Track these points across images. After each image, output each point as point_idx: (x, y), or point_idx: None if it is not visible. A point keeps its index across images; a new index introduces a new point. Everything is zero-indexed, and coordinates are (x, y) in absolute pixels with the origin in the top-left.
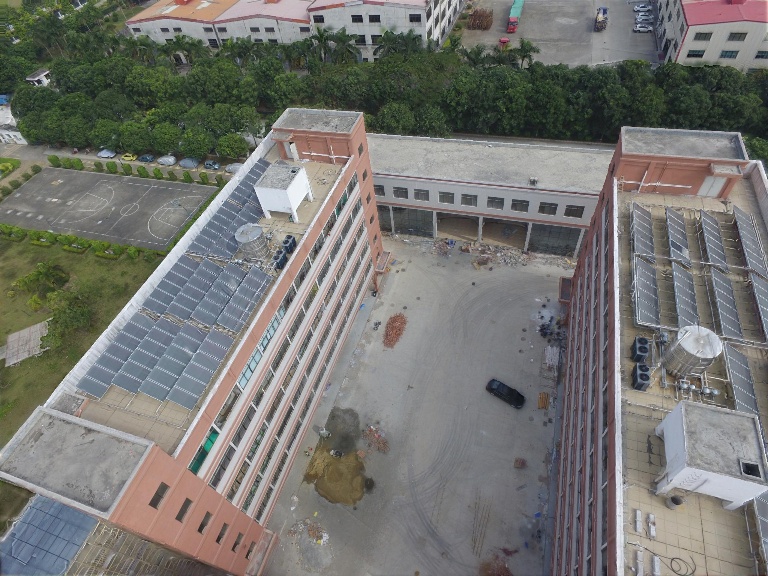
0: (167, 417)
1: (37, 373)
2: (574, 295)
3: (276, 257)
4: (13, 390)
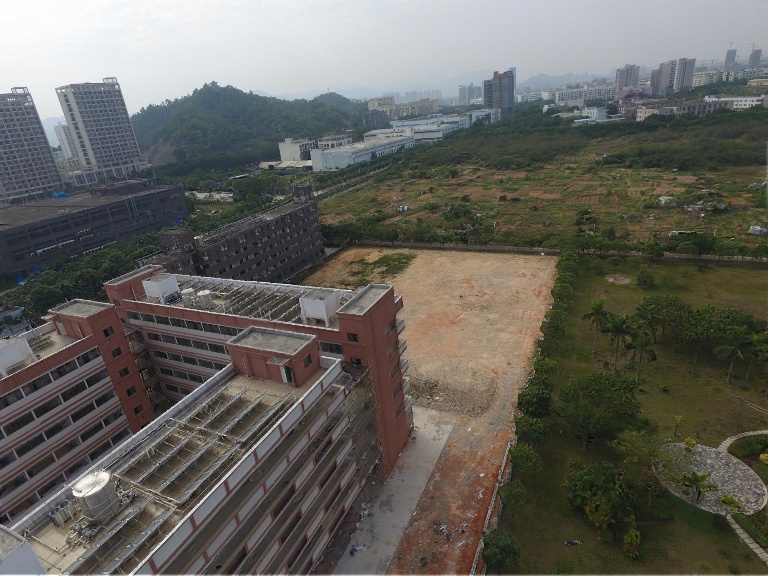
0: (239, 390)
1: None
2: None
3: None
4: None
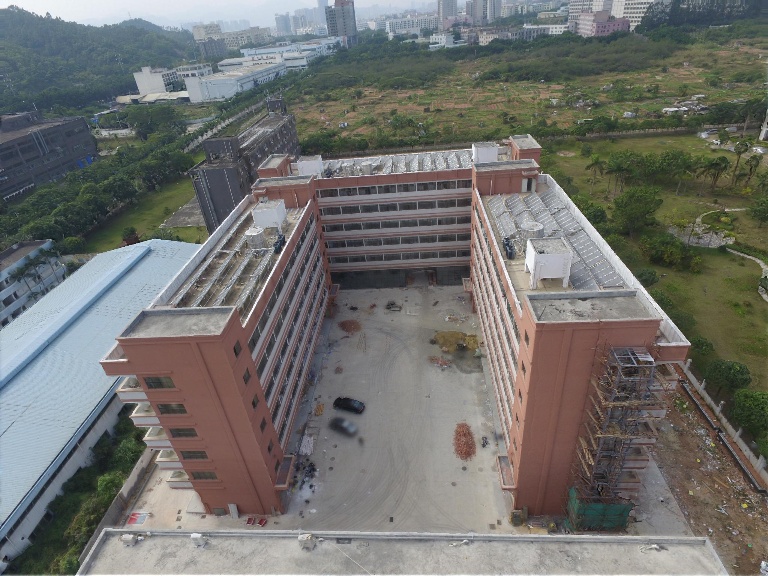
0: None
1: (762, 332)
2: (280, 446)
3: (507, 239)
4: (760, 320)
